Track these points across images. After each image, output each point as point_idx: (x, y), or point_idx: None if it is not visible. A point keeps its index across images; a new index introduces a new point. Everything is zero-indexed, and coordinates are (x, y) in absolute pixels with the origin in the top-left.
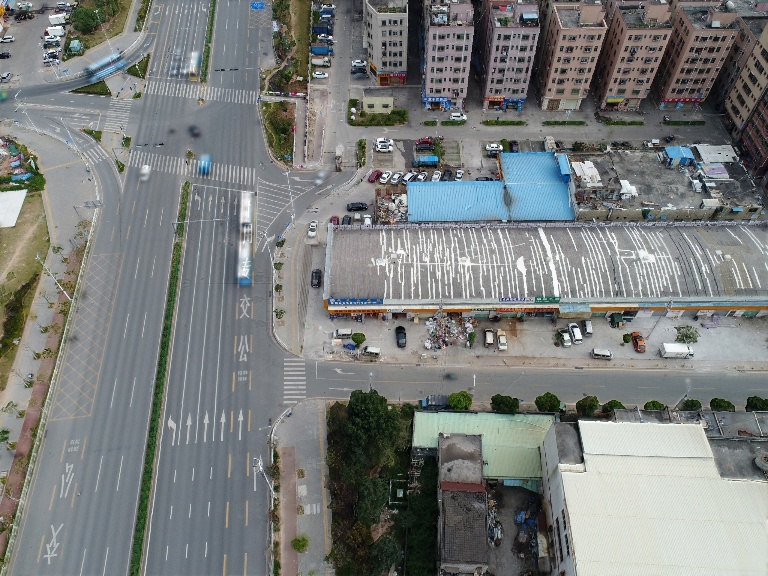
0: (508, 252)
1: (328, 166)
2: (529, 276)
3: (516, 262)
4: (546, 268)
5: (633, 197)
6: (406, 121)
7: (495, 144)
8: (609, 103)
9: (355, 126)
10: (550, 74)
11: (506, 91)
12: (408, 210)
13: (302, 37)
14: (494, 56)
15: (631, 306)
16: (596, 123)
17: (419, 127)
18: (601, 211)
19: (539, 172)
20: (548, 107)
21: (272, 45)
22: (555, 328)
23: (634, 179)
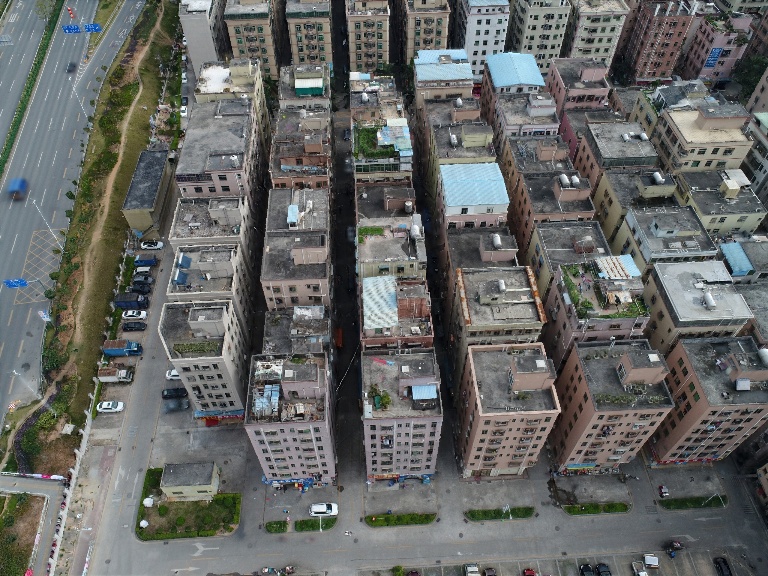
0: None
1: None
2: None
3: None
4: None
5: None
6: (235, 523)
7: None
8: None
9: (146, 541)
10: (470, 452)
11: (400, 468)
12: None
13: (93, 323)
14: (370, 443)
15: None
16: (551, 509)
17: (256, 537)
18: None
19: None
20: (473, 474)
21: (41, 345)
22: None
23: None
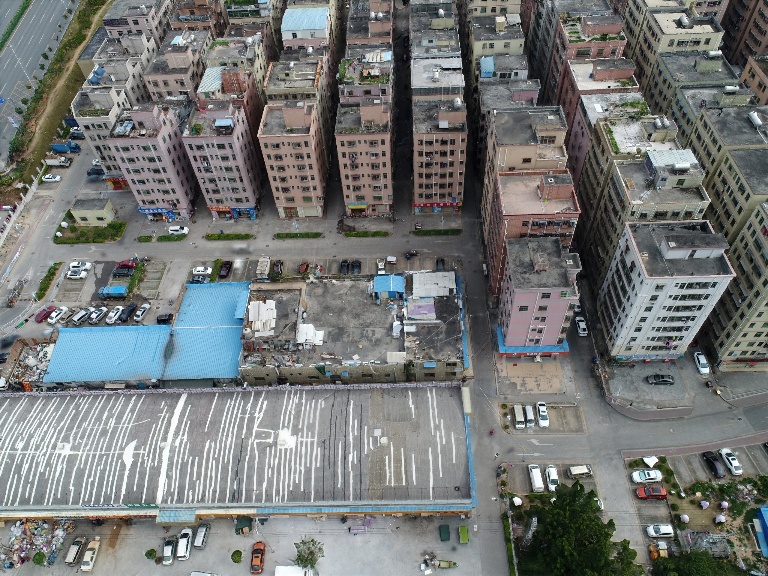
0: (122, 434)
1: (1, 300)
2: (133, 470)
3: (124, 449)
4: (157, 458)
5: (311, 348)
6: (119, 237)
7: (202, 267)
8: (355, 209)
9: (59, 244)
10: (270, 182)
11: (229, 200)
12: (48, 367)
13: (48, 132)
14: (196, 166)
15: (246, 512)
16: (335, 234)
17: (131, 244)
18: (266, 368)
19: (222, 311)
20: (286, 214)
21: None
22: (165, 535)
23: (327, 320)
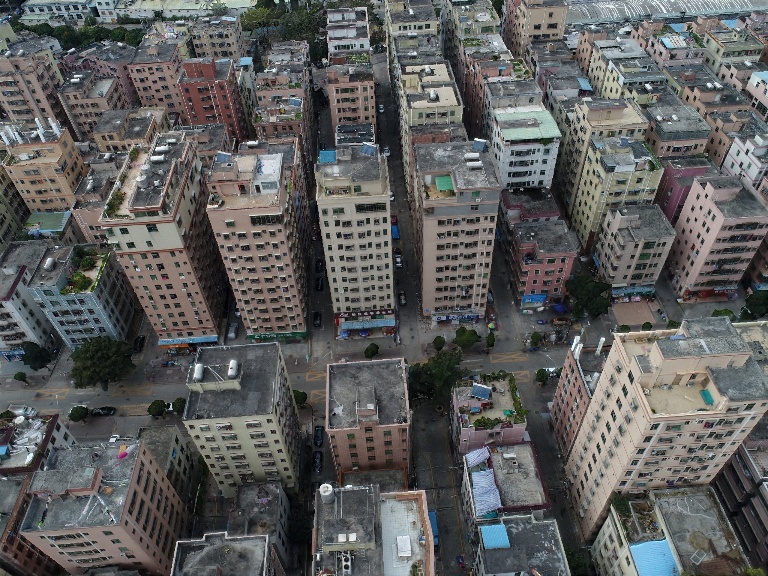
0: (681, 2)
1: None
2: None
3: (675, 0)
4: None
5: None
6: None
7: None
8: None
9: None
10: None
11: None
12: None
13: None
14: None
15: None
16: None
17: None
18: None
19: None
20: None
21: None
22: None
23: None
